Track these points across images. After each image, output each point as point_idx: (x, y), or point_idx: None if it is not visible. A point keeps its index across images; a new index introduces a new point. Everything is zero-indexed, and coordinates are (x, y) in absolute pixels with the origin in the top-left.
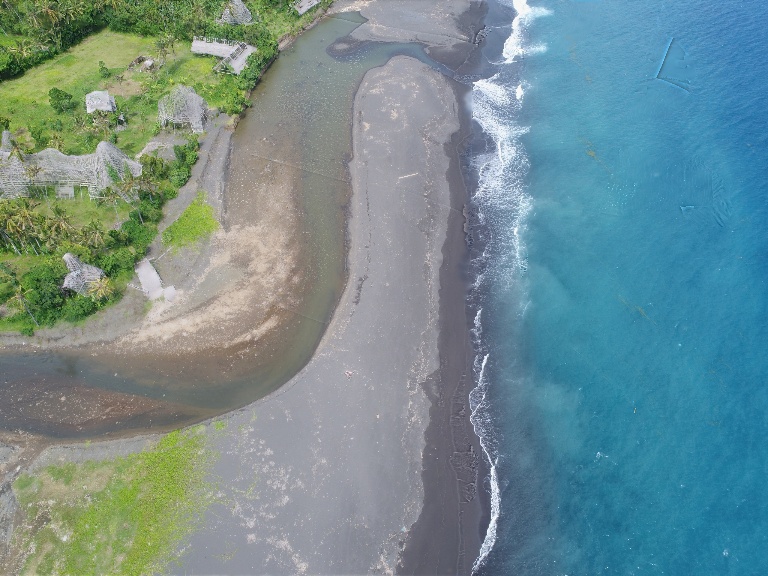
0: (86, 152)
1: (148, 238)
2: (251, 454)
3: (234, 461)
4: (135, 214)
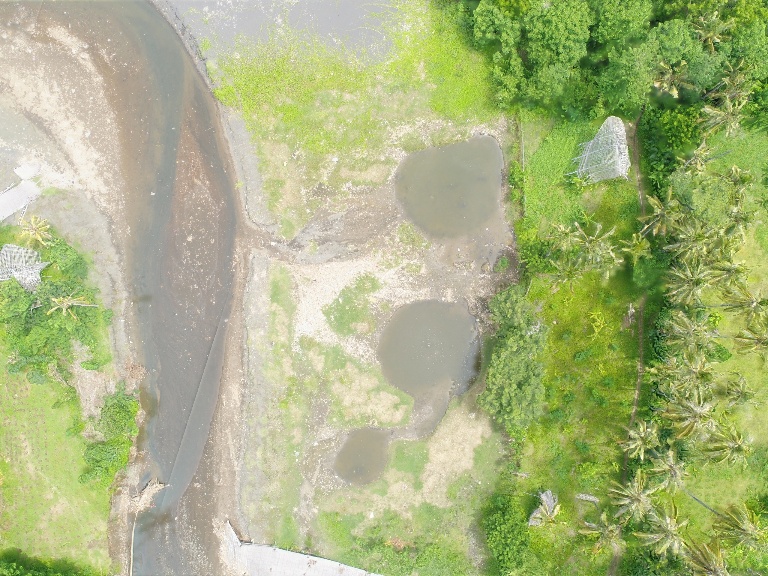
0: None
1: None
2: (234, 1)
3: (243, 17)
4: None
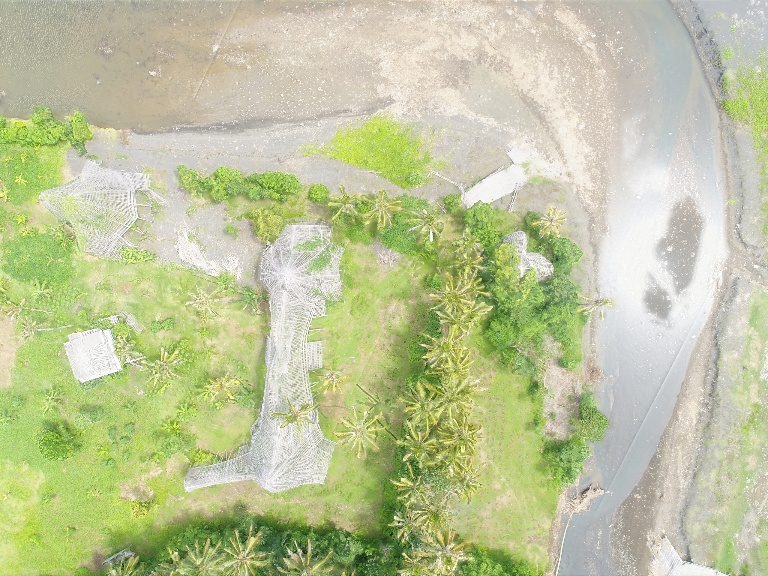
0: (200, 360)
1: (417, 206)
2: (766, 12)
3: None
4: (387, 224)
